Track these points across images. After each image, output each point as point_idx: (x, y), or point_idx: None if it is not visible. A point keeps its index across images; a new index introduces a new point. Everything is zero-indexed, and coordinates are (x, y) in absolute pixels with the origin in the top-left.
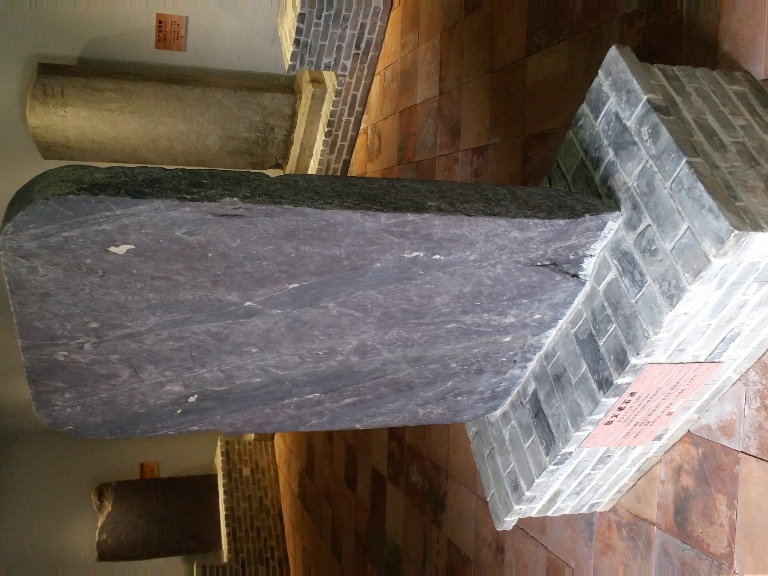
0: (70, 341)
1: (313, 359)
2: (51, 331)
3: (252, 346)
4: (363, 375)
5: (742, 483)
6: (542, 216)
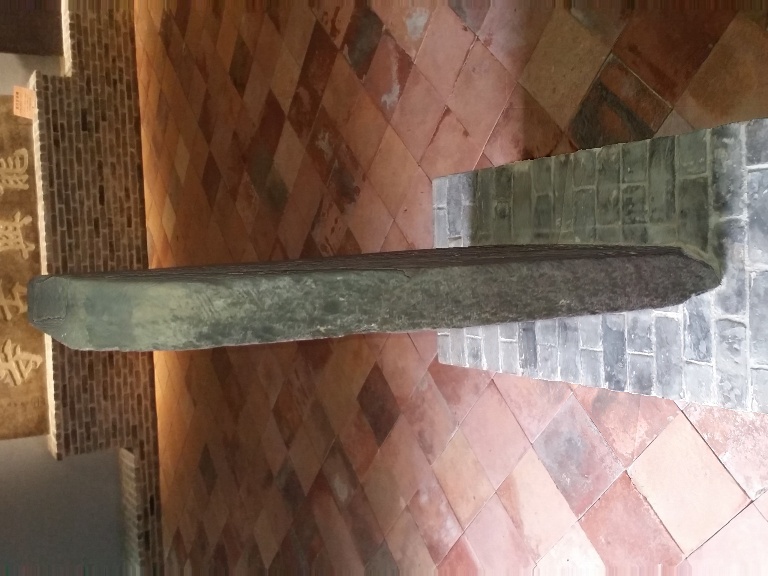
0: None
1: None
2: None
3: None
4: None
5: (669, 430)
6: (656, 304)
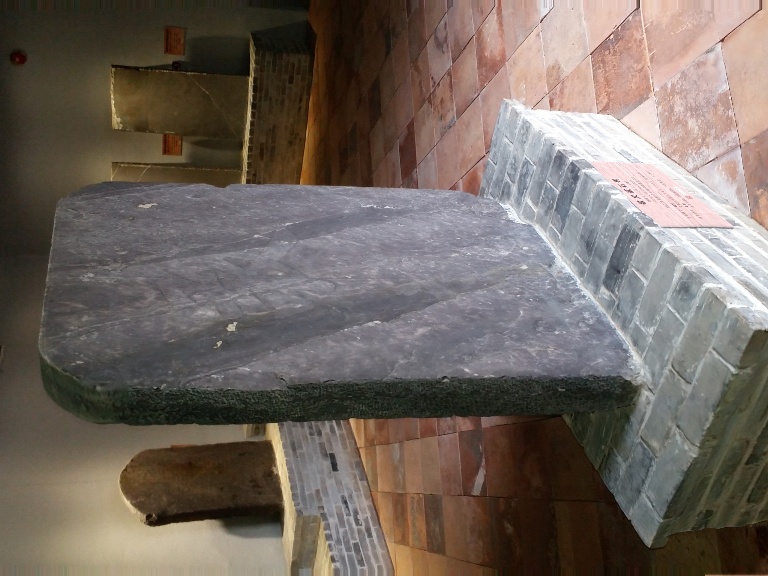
0: (98, 266)
1: (345, 283)
2: None
3: None
4: (413, 301)
5: (759, 128)
6: None
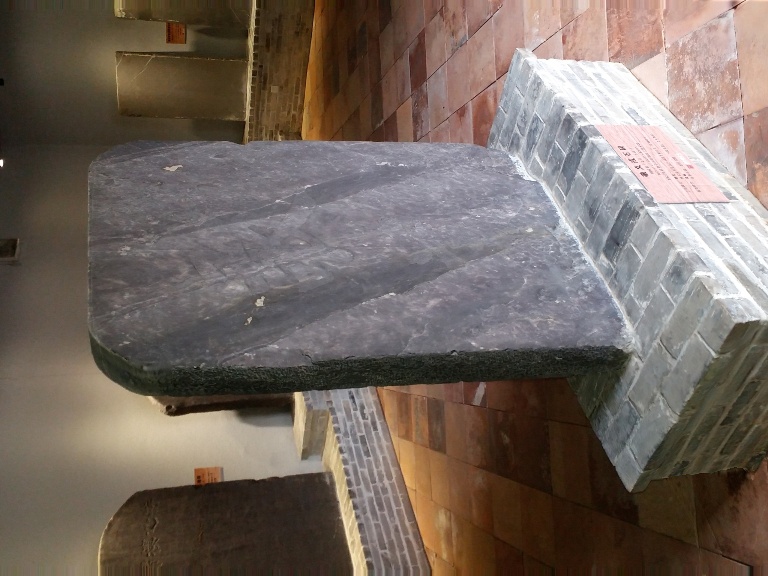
0: (133, 238)
1: (362, 252)
2: (118, 228)
3: (298, 240)
4: (425, 270)
5: (762, 104)
6: None
